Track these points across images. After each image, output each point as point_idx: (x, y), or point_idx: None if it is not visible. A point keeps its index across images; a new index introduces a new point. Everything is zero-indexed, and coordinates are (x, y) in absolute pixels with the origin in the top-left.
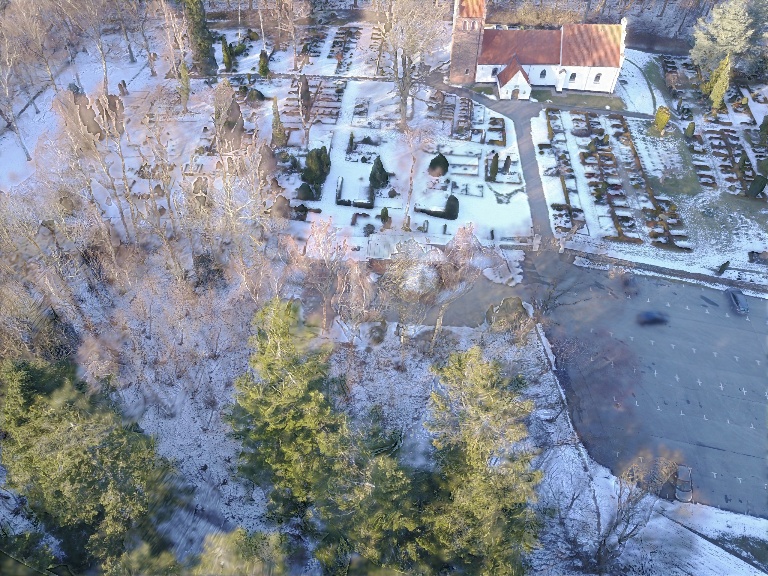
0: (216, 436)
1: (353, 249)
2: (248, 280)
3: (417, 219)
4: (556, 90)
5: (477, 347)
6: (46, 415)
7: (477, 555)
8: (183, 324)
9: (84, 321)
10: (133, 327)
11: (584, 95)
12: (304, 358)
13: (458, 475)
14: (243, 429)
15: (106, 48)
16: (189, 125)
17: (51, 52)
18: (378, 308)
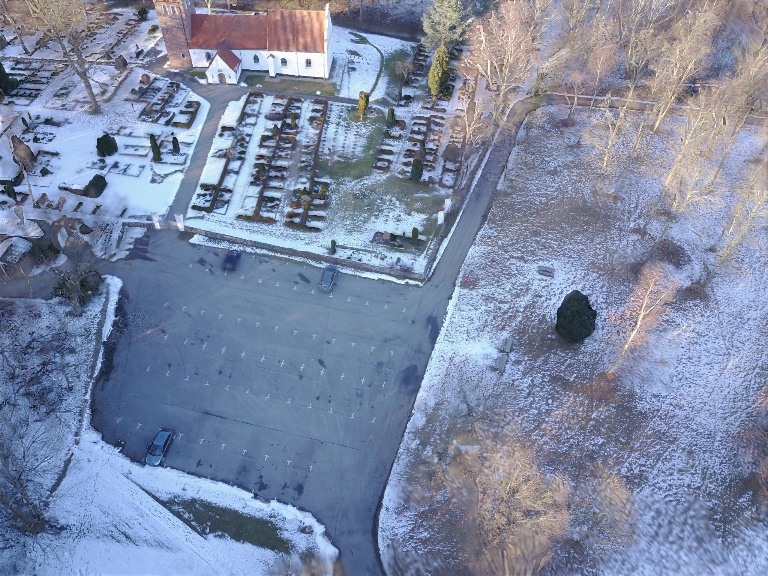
0: None
1: None
2: None
3: (58, 197)
4: (269, 75)
5: (29, 318)
6: None
7: None
8: None
9: None
10: None
11: (298, 80)
12: None
13: None
14: None
15: None
16: None
17: None
18: None
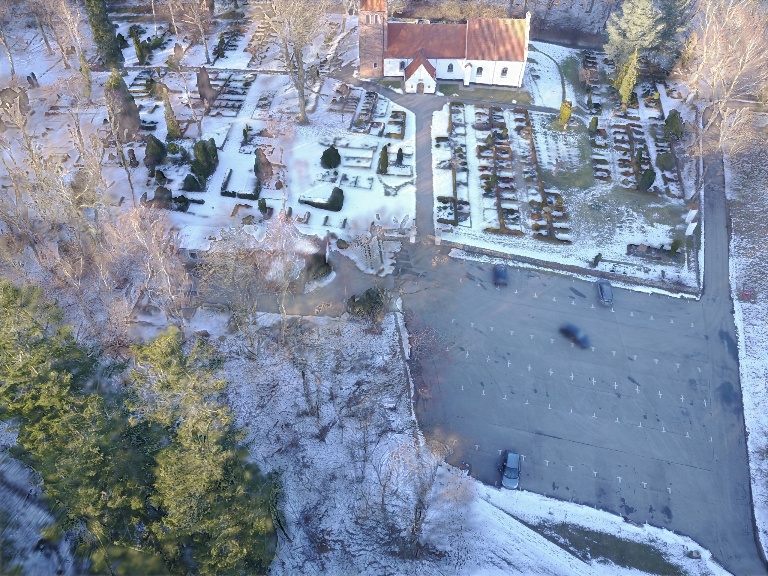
0: None
1: None
2: (66, 266)
3: (300, 210)
4: (463, 84)
5: (331, 336)
6: None
7: (202, 532)
8: (50, 313)
9: None
10: (2, 316)
11: (492, 89)
12: None
13: (164, 452)
14: None
15: None
16: (91, 117)
17: None
18: (187, 294)
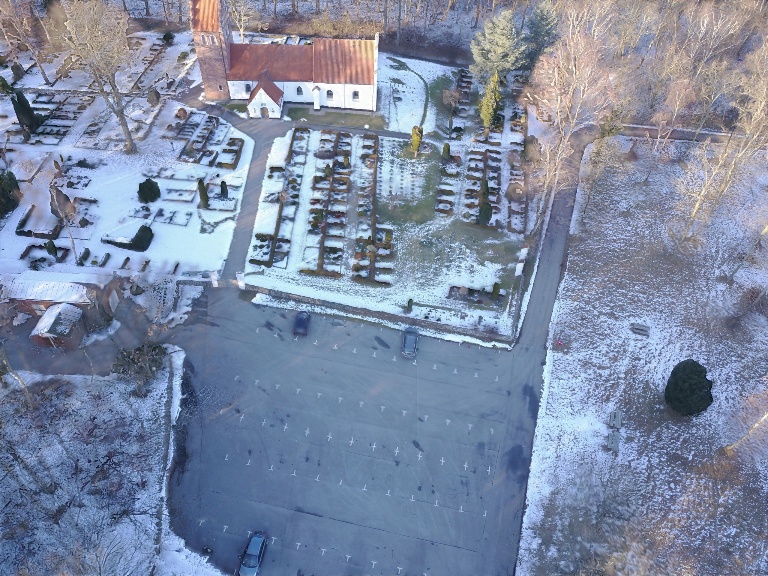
0: None
1: None
2: None
3: (101, 251)
4: (314, 108)
5: (88, 400)
6: None
7: None
8: None
9: None
10: None
11: (344, 113)
12: None
13: None
14: None
15: None
16: None
17: None
18: None
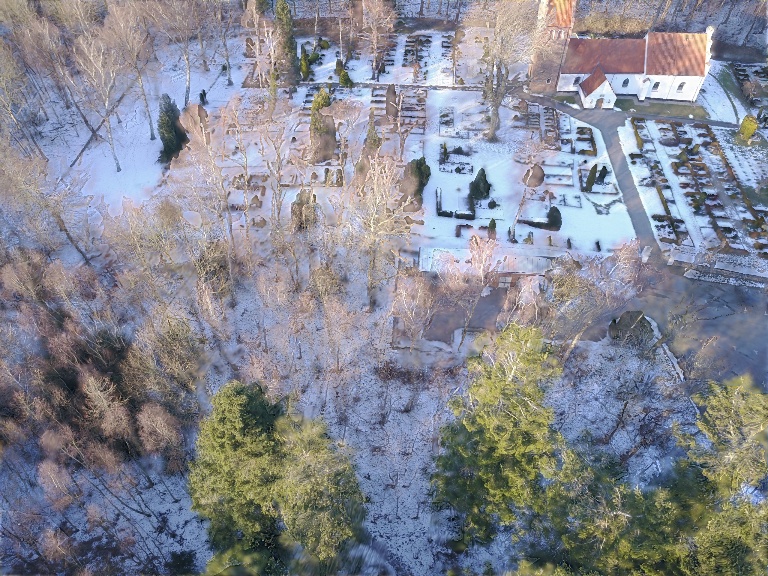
0: (352, 453)
1: (467, 262)
2: (408, 297)
3: (520, 230)
4: (639, 99)
5: (606, 362)
6: (261, 439)
7: None
8: (300, 338)
9: (197, 334)
10: (248, 341)
11: (666, 104)
12: (432, 373)
13: (719, 504)
14: (471, 455)
15: (177, 57)
16: None
17: (144, 63)
18: (546, 326)
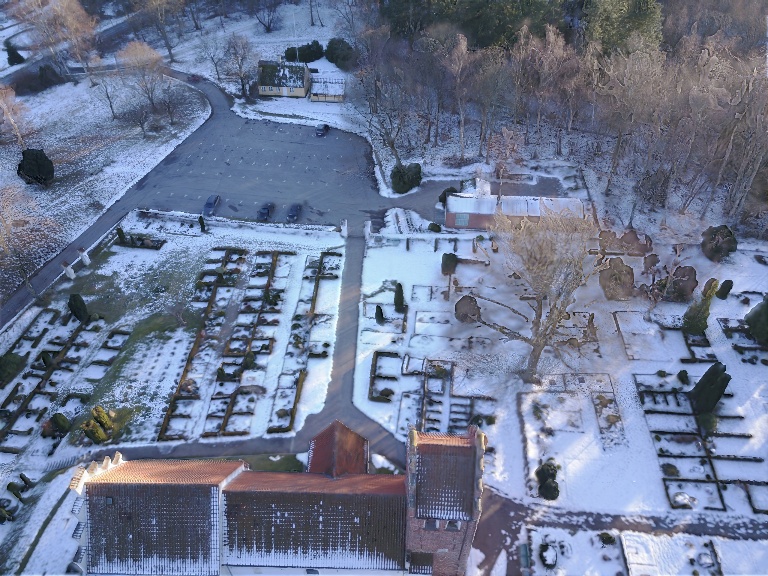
0: None
1: None
2: None
3: (485, 256)
4: None
5: None
6: None
7: None
8: None
9: None
10: None
11: None
12: None
13: None
14: None
15: None
16: None
17: None
18: None
